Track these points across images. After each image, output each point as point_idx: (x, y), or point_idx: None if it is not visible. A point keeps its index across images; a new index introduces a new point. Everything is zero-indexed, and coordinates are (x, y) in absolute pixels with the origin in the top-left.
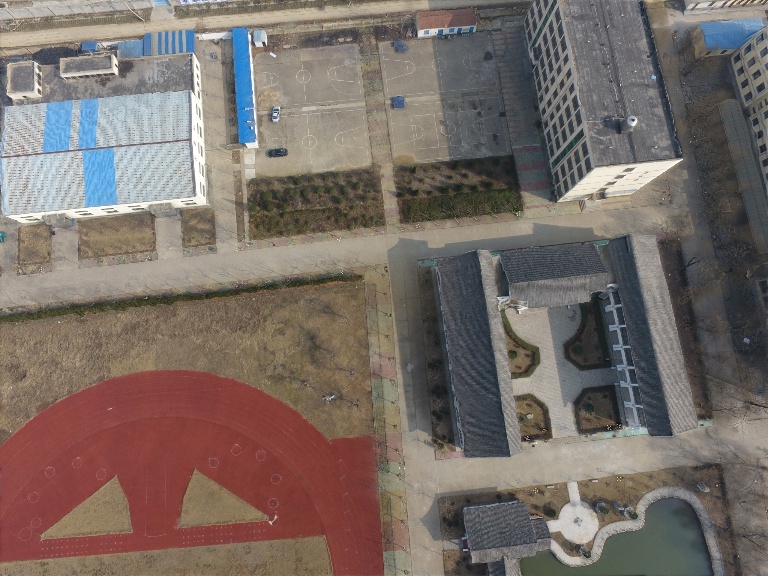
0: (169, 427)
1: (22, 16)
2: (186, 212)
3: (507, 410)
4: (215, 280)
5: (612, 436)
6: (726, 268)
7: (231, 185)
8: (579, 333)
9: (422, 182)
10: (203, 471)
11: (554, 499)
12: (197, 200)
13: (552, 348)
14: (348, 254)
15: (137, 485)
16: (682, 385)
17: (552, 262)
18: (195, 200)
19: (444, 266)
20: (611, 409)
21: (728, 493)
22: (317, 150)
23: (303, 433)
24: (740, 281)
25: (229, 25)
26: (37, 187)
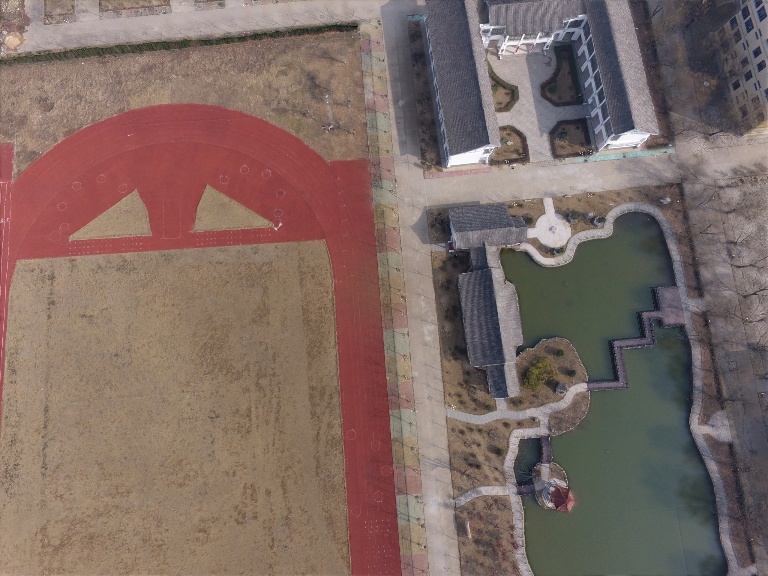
0: (183, 150)
1: None
2: None
3: None
4: (224, 30)
5: (584, 161)
6: (688, 21)
7: None
8: (554, 75)
9: None
10: (215, 186)
11: (531, 211)
12: None
13: (530, 88)
14: (345, 10)
15: (155, 197)
16: (645, 98)
17: None
18: None
19: (431, 0)
20: (583, 138)
21: (688, 207)
22: None
23: (305, 156)
24: (701, 35)
25: None
26: None
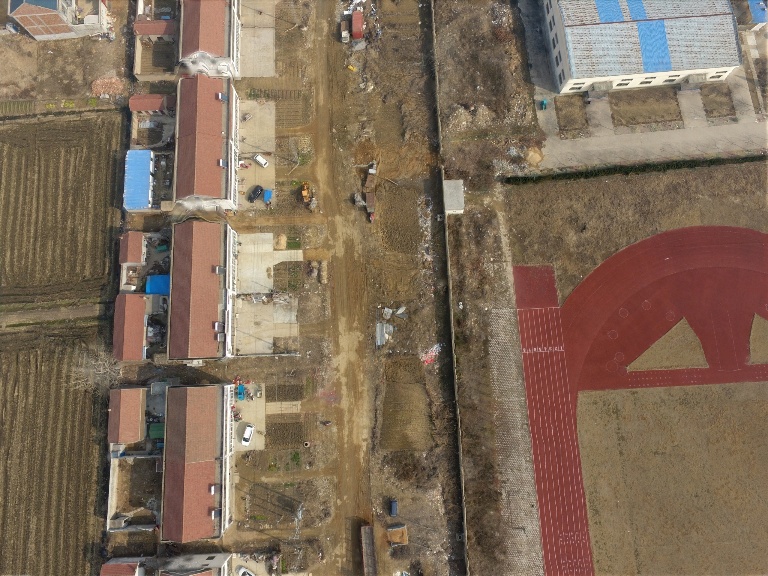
0: (724, 276)
1: None
2: (704, 86)
3: None
4: (742, 147)
5: None
6: None
7: None
8: None
9: None
10: (763, 315)
11: None
12: (728, 72)
13: None
14: None
15: (705, 326)
16: None
17: None
18: (728, 72)
19: None
20: None
21: None
22: None
23: None
24: None
25: None
26: (599, 54)
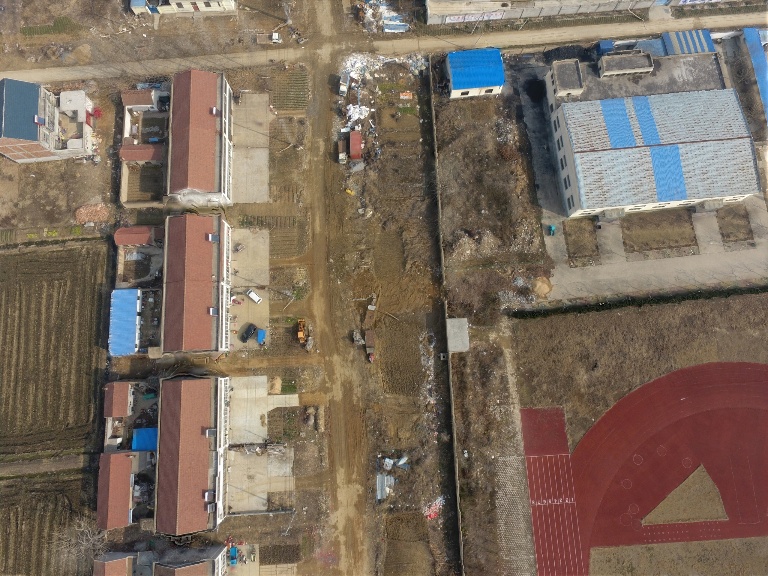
0: (743, 418)
1: (529, 15)
2: (720, 208)
3: None
4: (760, 275)
5: None
6: None
7: None
8: None
9: None
10: None
11: None
12: (746, 196)
13: None
14: None
15: (724, 474)
16: None
17: None
18: (746, 196)
19: None
20: None
21: None
22: None
23: None
24: None
25: (725, 25)
26: (610, 182)
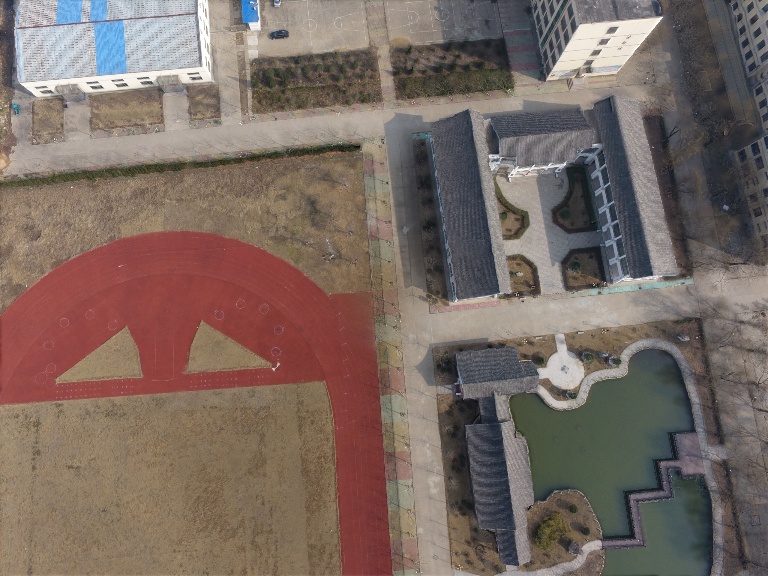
0: (177, 283)
1: None
2: (192, 88)
3: (497, 251)
4: (220, 150)
5: (597, 293)
6: (707, 140)
7: (235, 64)
8: (566, 199)
9: (417, 62)
10: (209, 322)
11: (542, 349)
12: (203, 73)
13: (541, 213)
14: (347, 127)
15: (147, 335)
16: (663, 235)
17: (540, 123)
18: (201, 73)
19: (438, 128)
20: (597, 268)
21: (707, 344)
22: (317, 33)
23: (304, 289)
24: (720, 153)
25: None
26: (51, 56)
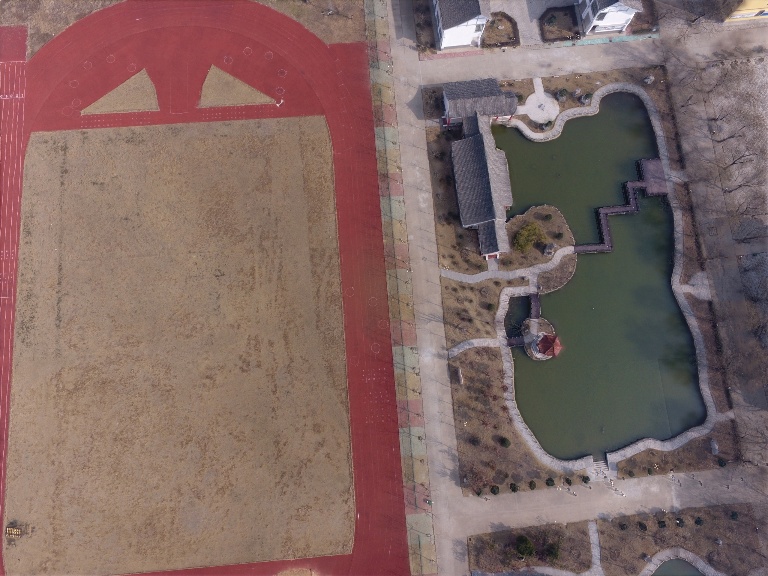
0: (189, 33)
1: None
2: None
3: None
4: None
5: (572, 45)
6: None
7: None
8: None
9: None
10: (219, 66)
11: (521, 90)
12: None
13: None
14: None
15: (163, 76)
16: None
17: None
18: None
19: None
20: (571, 24)
21: (671, 87)
22: None
23: (305, 39)
24: None
25: None
26: None
